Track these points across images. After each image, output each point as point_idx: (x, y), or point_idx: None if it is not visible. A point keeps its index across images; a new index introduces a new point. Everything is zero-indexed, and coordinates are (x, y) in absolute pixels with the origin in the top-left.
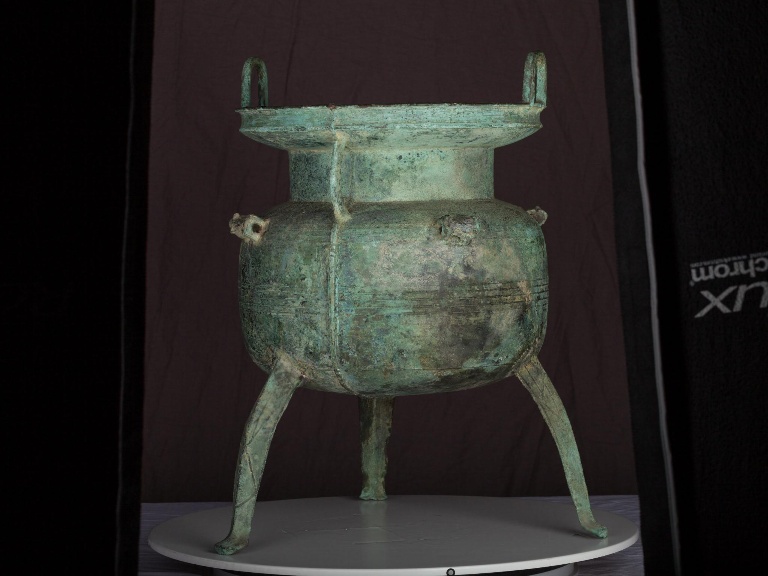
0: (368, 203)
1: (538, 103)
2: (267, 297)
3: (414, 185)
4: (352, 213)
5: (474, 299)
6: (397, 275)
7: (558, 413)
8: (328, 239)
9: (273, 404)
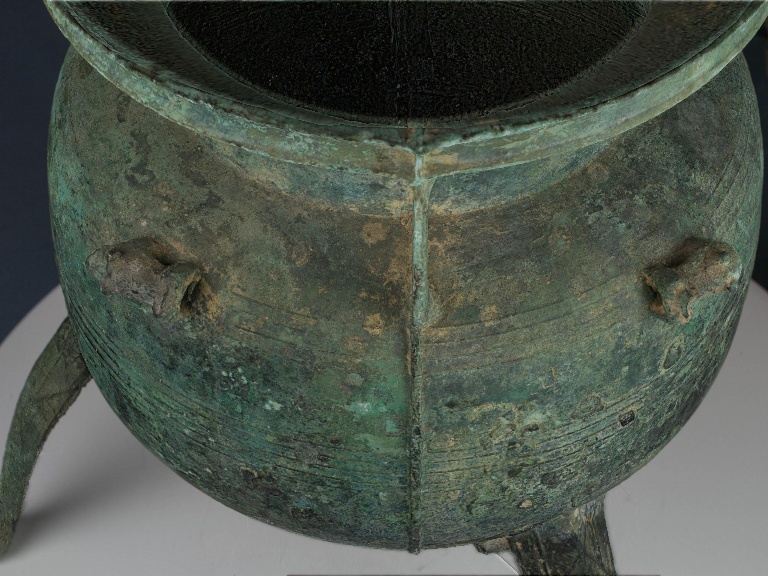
0: None
1: None
2: None
3: None
4: None
5: None
6: None
7: None
8: None
9: None
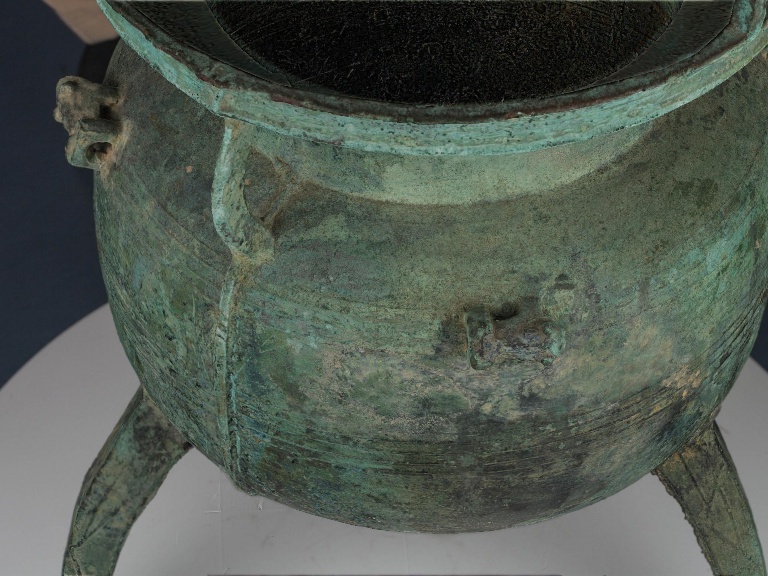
0: (327, 196)
1: None
2: (116, 296)
3: (438, 175)
4: (278, 238)
5: (542, 446)
6: (360, 409)
7: (737, 540)
8: (216, 295)
9: (127, 486)
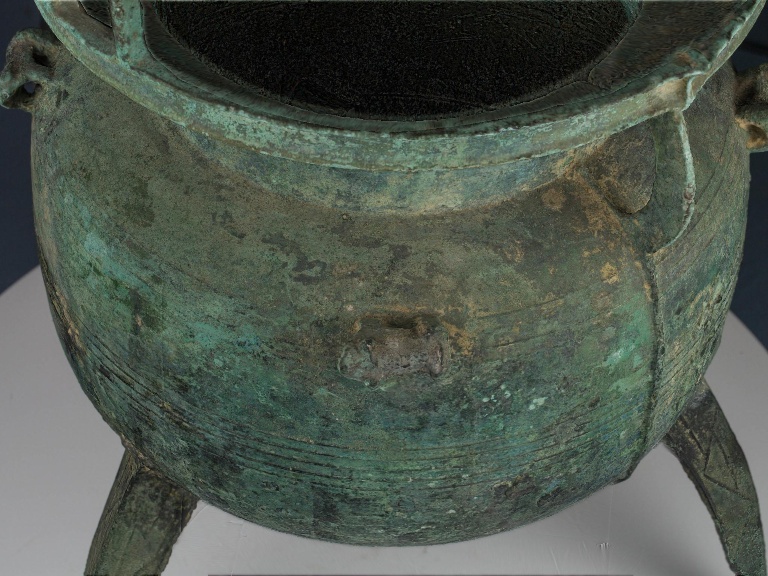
0: None
1: (73, 28)
2: None
3: None
4: None
5: None
6: None
7: None
8: None
9: None
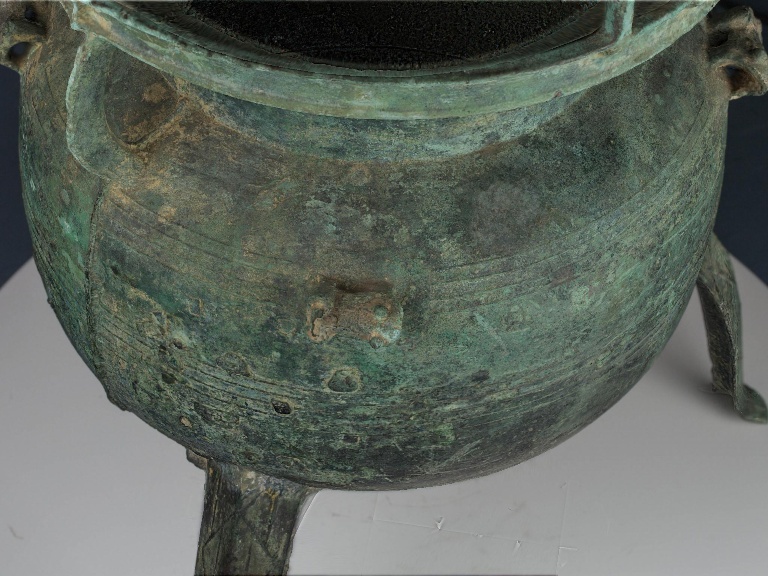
0: None
1: None
2: None
3: None
4: None
5: None
6: None
7: None
8: None
9: None
